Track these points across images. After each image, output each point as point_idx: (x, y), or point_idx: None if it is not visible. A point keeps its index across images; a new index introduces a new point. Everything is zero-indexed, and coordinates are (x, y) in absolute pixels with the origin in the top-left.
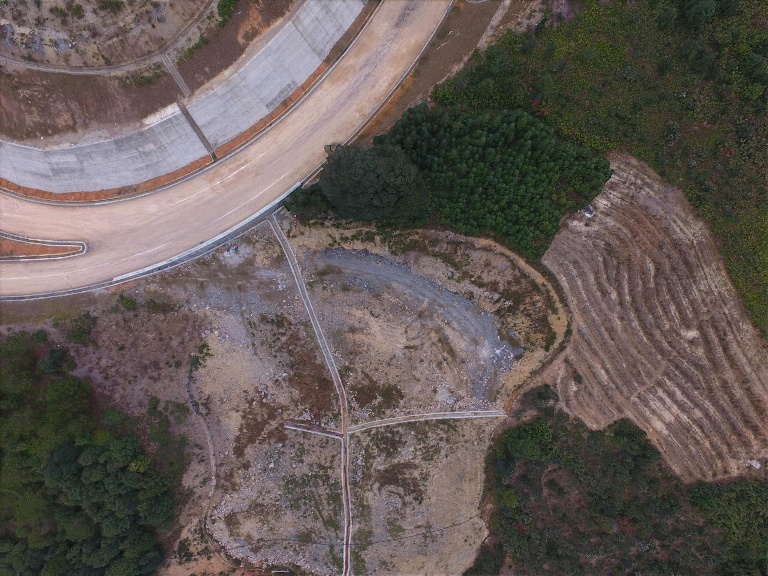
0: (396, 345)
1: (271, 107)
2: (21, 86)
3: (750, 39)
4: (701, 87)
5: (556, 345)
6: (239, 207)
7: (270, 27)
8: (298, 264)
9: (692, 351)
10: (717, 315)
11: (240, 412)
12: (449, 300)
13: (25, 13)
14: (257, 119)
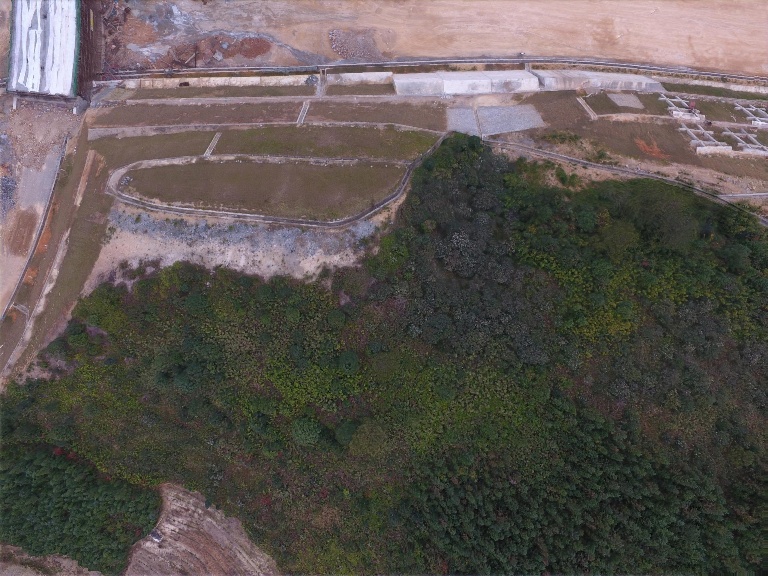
0: None
1: None
2: None
3: None
4: (228, 435)
5: None
6: None
7: None
8: None
9: None
10: None
11: None
12: None
13: None
14: None
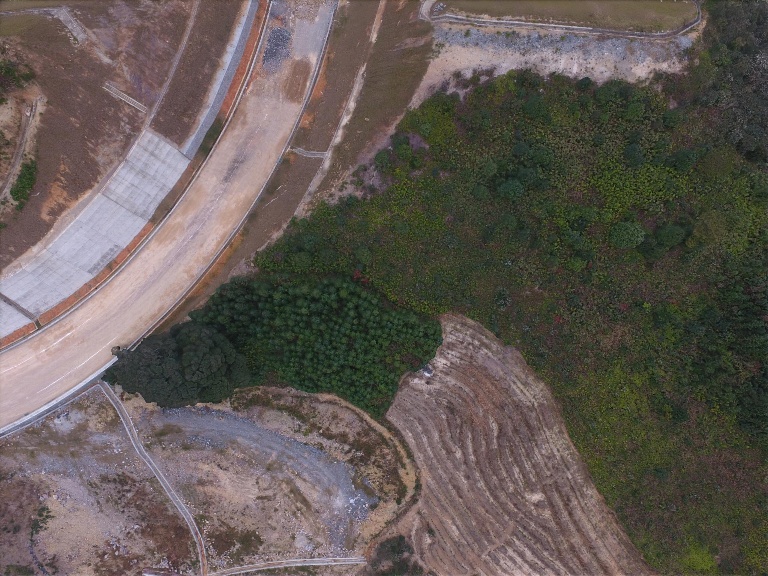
0: (248, 496)
1: (95, 271)
2: None
3: (567, 214)
4: (527, 255)
5: (407, 498)
6: (64, 376)
7: (79, 200)
8: (134, 426)
9: (538, 513)
10: (560, 480)
11: (92, 565)
12: (299, 451)
13: None
14: (81, 284)
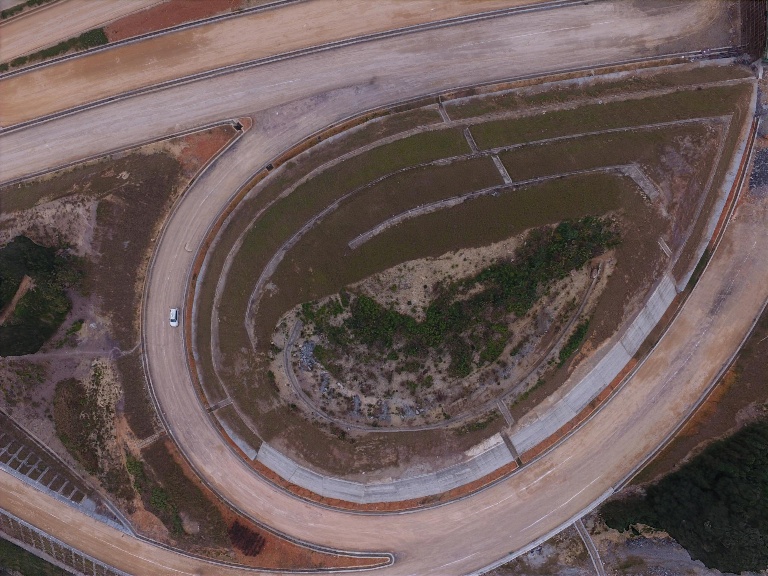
0: None
1: (579, 410)
2: (359, 444)
3: None
4: None
5: None
6: (548, 515)
7: (597, 349)
8: (600, 559)
9: None
10: None
11: None
12: None
13: (374, 387)
14: (564, 423)
